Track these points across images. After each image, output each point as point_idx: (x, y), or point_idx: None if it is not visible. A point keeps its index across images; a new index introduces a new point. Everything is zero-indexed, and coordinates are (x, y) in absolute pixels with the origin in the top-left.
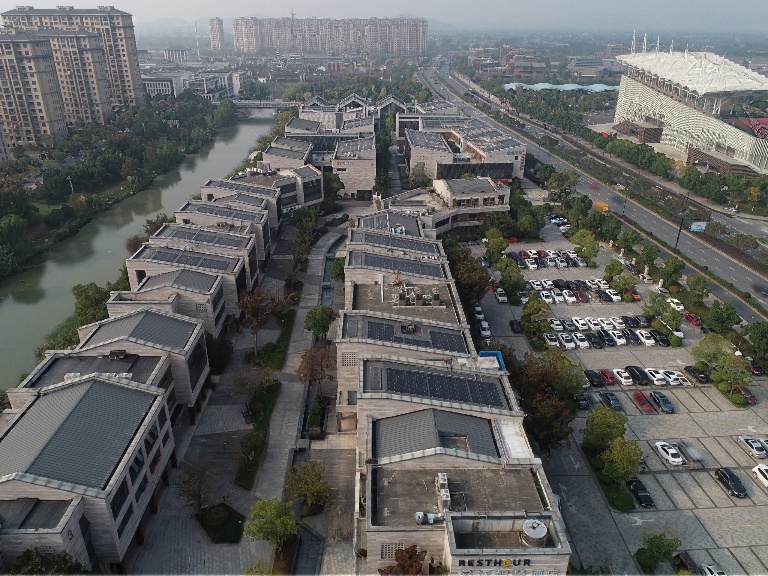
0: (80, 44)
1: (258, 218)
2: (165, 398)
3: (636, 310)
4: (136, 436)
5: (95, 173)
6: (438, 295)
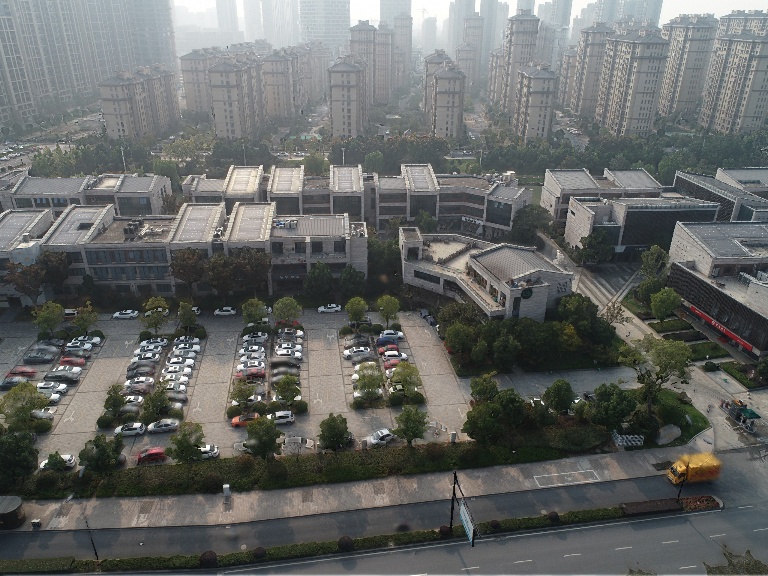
0: (754, 50)
1: (348, 190)
2: (81, 196)
3: (204, 416)
4: None
5: (539, 159)
6: (124, 229)
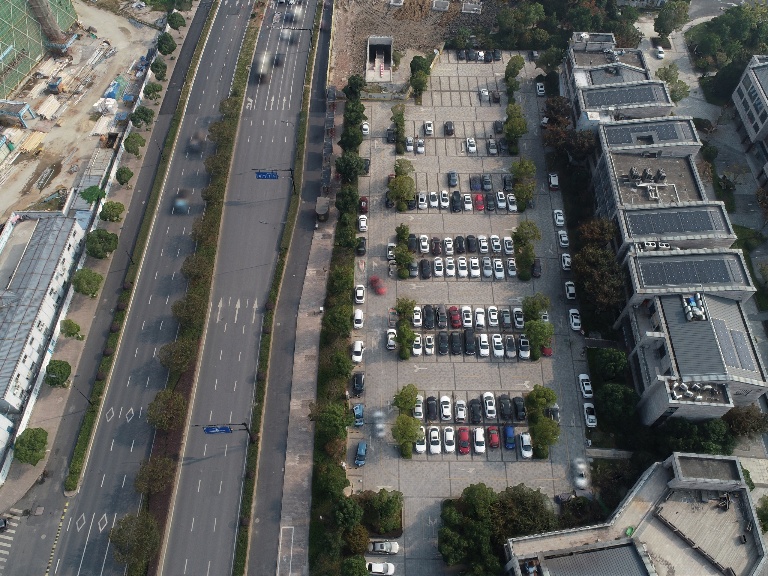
0: None
1: None
2: None
3: (405, 292)
4: (763, 91)
5: None
6: None
